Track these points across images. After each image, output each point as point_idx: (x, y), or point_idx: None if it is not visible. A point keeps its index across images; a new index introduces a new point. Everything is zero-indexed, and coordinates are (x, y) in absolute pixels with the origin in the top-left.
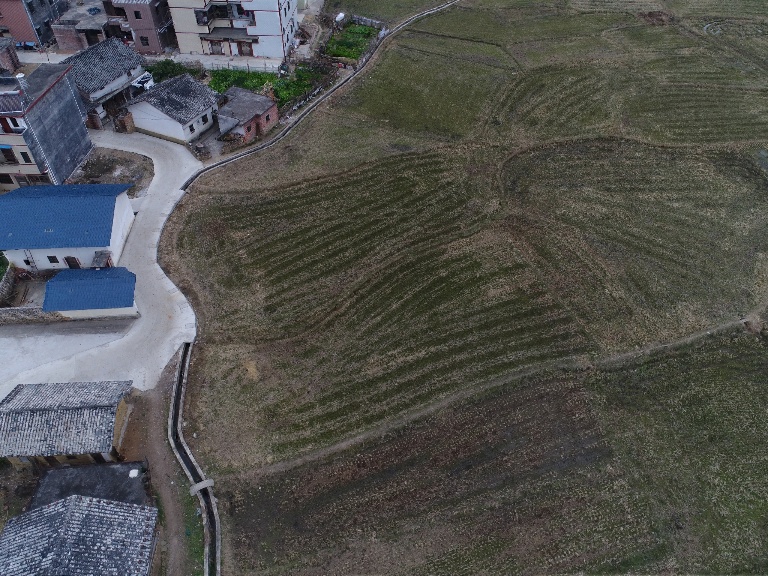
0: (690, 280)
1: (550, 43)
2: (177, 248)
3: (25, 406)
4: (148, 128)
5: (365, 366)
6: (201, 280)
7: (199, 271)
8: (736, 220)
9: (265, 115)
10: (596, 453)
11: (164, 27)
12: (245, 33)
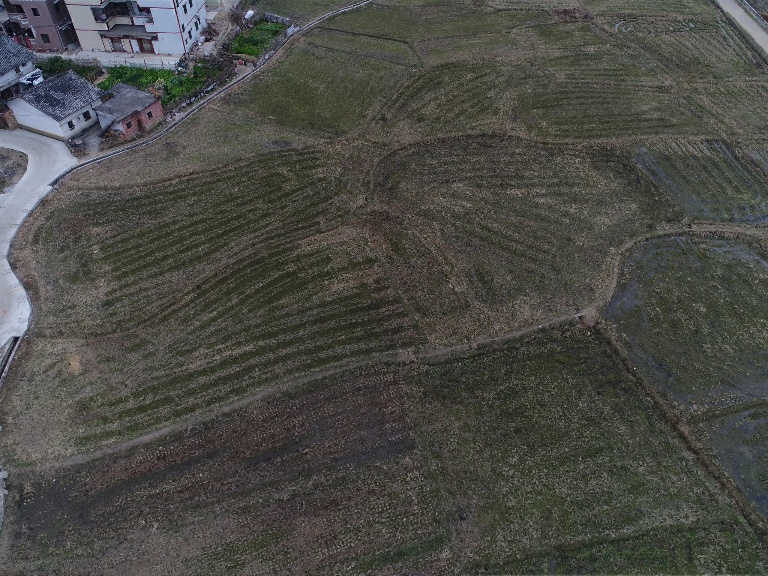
0: (536, 275)
1: (458, 40)
2: (31, 243)
3: None
4: (29, 125)
5: (189, 360)
6: (47, 275)
7: (47, 266)
8: (598, 215)
9: (146, 112)
10: (399, 445)
11: (66, 24)
12: (145, 30)
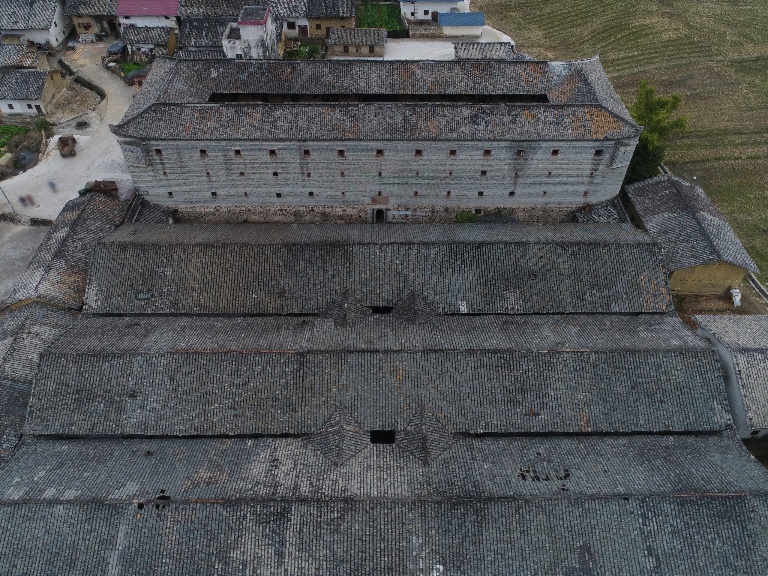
0: None
1: None
2: None
3: None
4: None
5: None
6: (503, 28)
7: (500, 25)
8: None
9: None
10: None
11: None
12: None
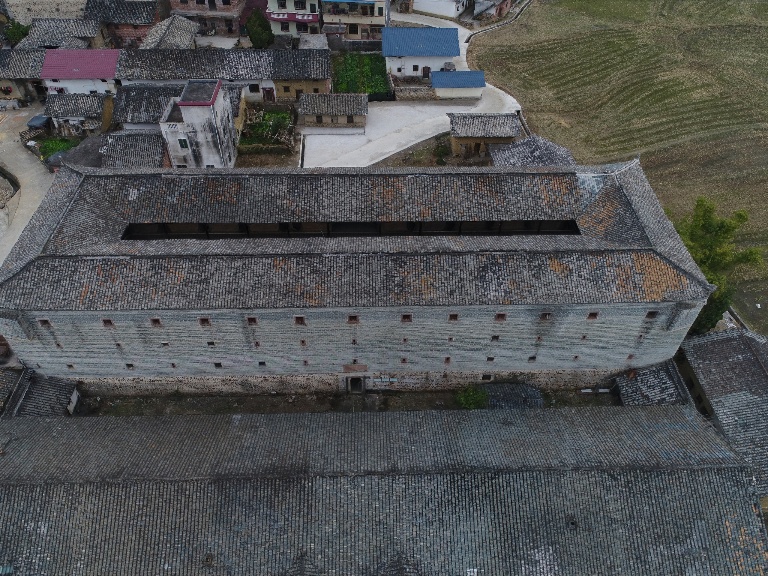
0: None
1: None
2: None
3: (466, 115)
4: (424, 10)
5: None
6: (507, 85)
7: (502, 81)
8: None
9: (506, 2)
10: None
11: None
12: None
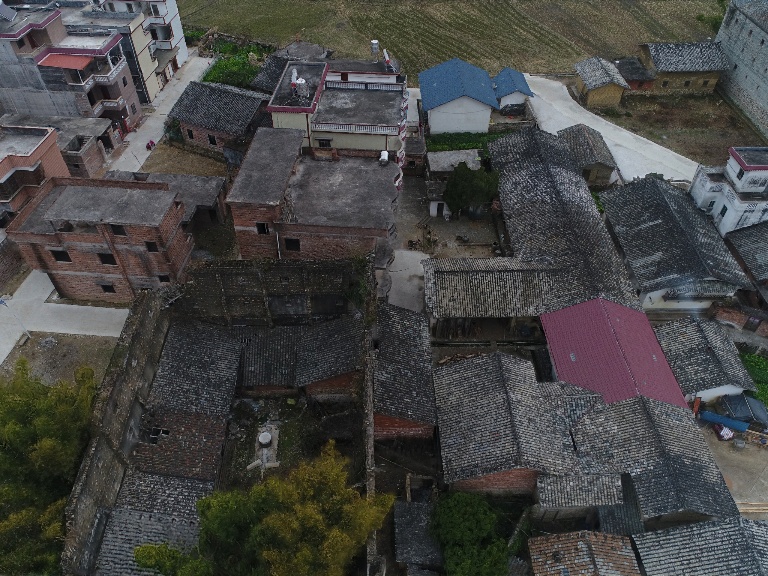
0: None
1: None
2: None
3: (606, 76)
4: None
5: None
6: None
7: None
8: None
9: None
10: (554, 6)
11: None
12: (164, 52)
